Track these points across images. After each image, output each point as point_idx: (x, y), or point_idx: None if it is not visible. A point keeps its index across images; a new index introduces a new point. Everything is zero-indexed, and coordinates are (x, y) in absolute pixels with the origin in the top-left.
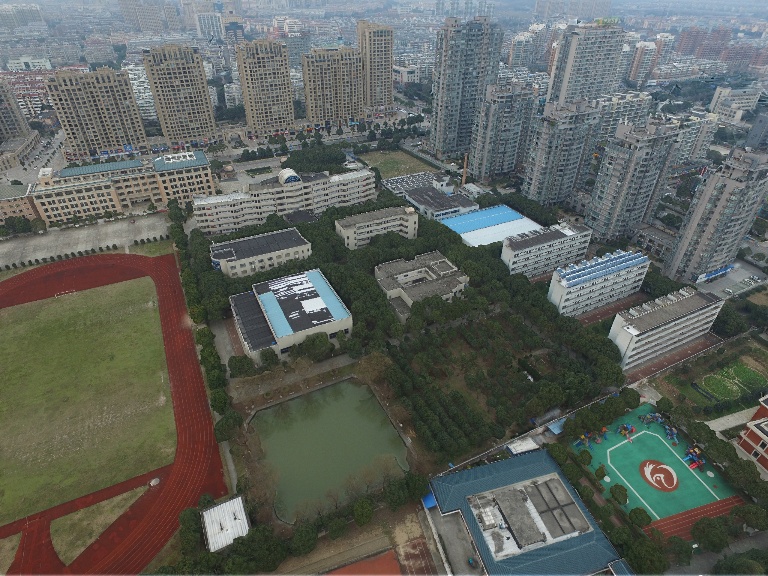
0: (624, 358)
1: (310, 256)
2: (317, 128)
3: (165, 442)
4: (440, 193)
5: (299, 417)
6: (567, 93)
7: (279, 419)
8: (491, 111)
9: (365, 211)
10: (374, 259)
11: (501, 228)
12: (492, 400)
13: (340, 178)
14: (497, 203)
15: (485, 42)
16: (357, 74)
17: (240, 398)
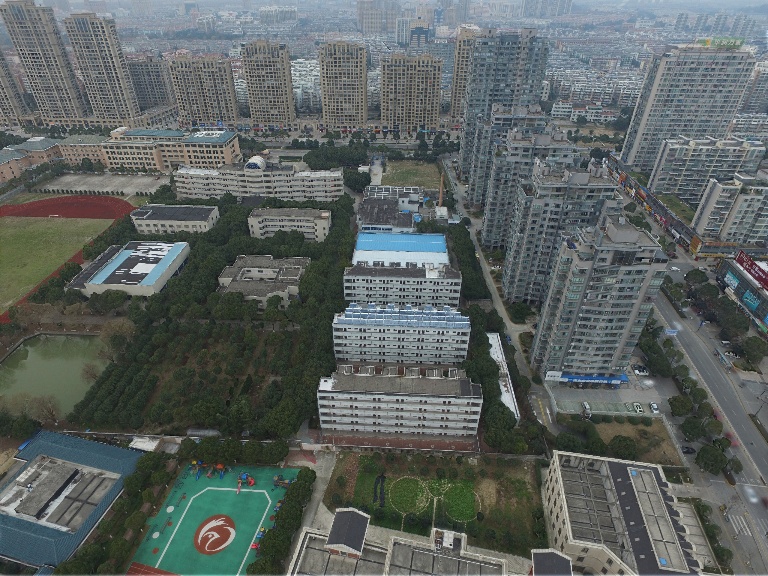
0: None
1: None
2: (385, 130)
3: None
4: (395, 209)
5: (81, 353)
6: (647, 128)
7: (63, 348)
8: (483, 132)
9: (295, 207)
10: (247, 249)
11: (406, 255)
12: (164, 395)
13: (308, 174)
14: (441, 232)
15: (522, 57)
16: (434, 82)
17: None
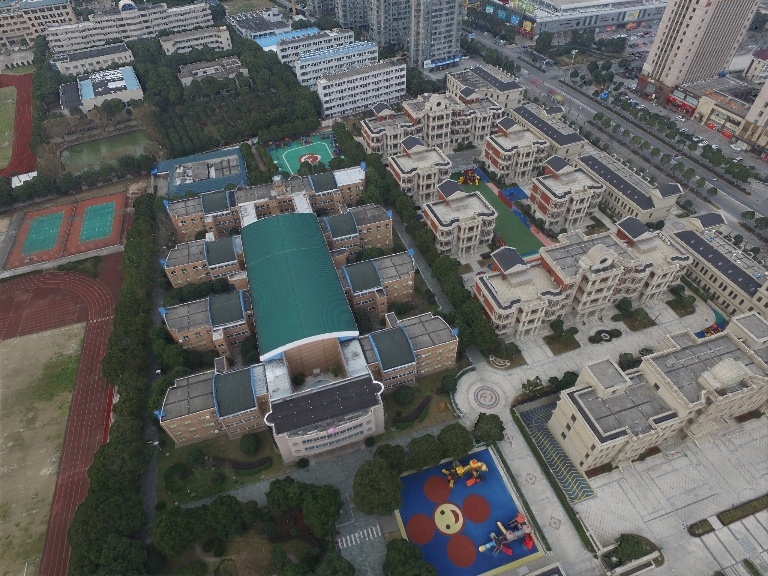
0: (323, 104)
1: (130, 60)
2: None
3: (3, 161)
4: (266, 21)
5: None
6: None
7: (90, 156)
8: None
9: None
10: (181, 62)
11: None
12: (219, 127)
13: (177, 9)
14: None
15: None
16: None
17: (48, 131)
